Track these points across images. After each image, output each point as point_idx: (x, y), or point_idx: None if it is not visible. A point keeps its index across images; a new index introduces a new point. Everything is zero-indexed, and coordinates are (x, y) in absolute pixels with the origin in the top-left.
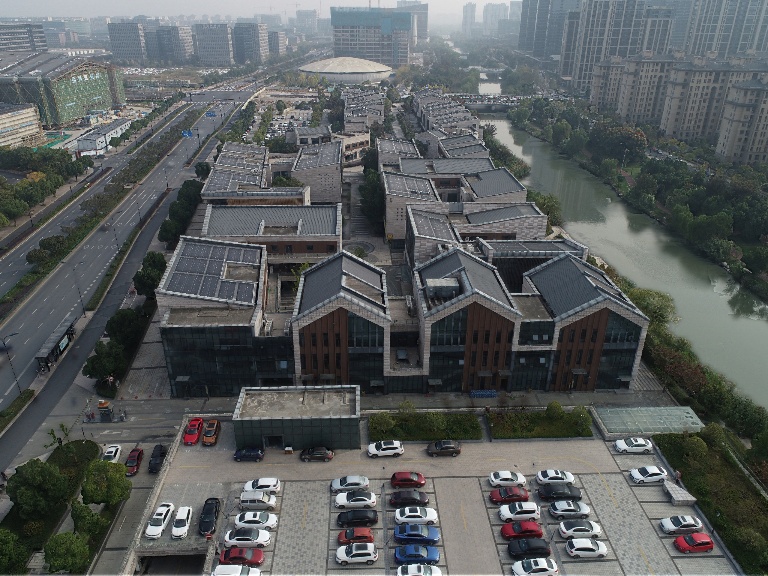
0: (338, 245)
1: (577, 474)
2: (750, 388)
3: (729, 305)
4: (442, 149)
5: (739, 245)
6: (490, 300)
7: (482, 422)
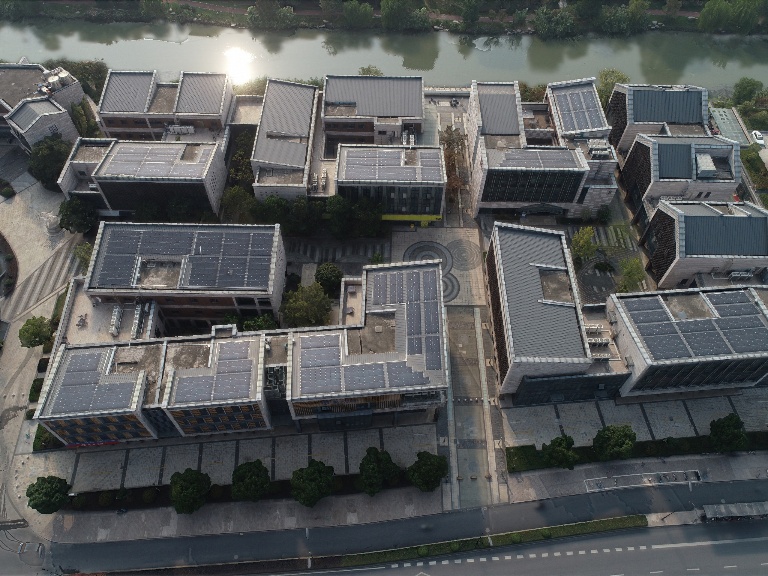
0: None
1: None
2: None
3: None
4: (151, 117)
5: None
6: None
7: (760, 193)
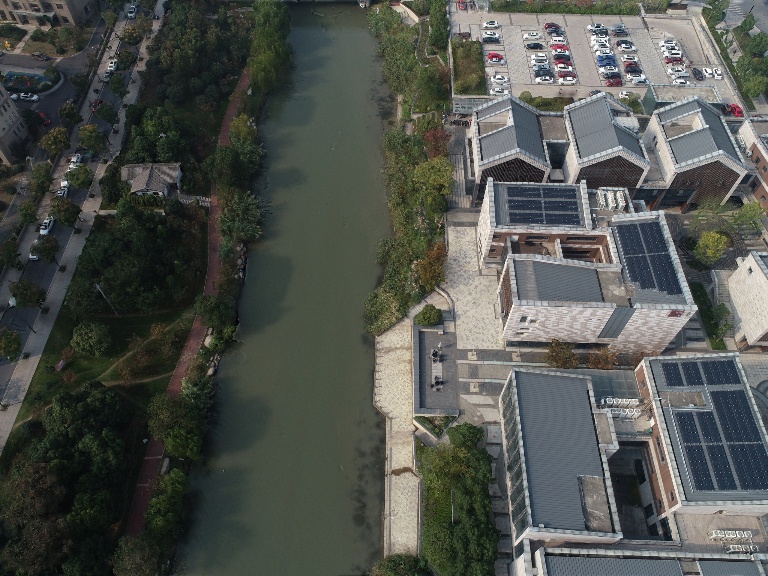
0: None
1: (532, 84)
2: (367, 177)
3: None
4: None
5: None
6: None
7: None
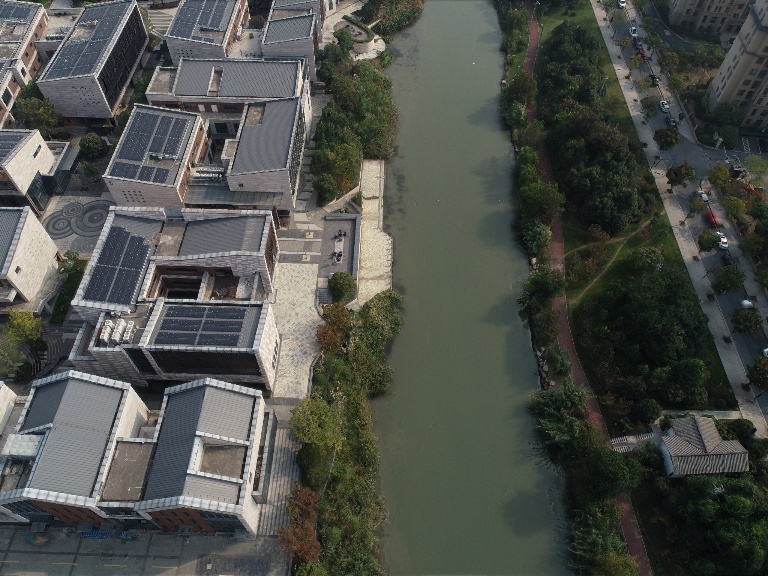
0: (10, 282)
1: None
2: (409, 514)
3: (519, 316)
4: None
5: (570, 226)
6: (45, 500)
7: None
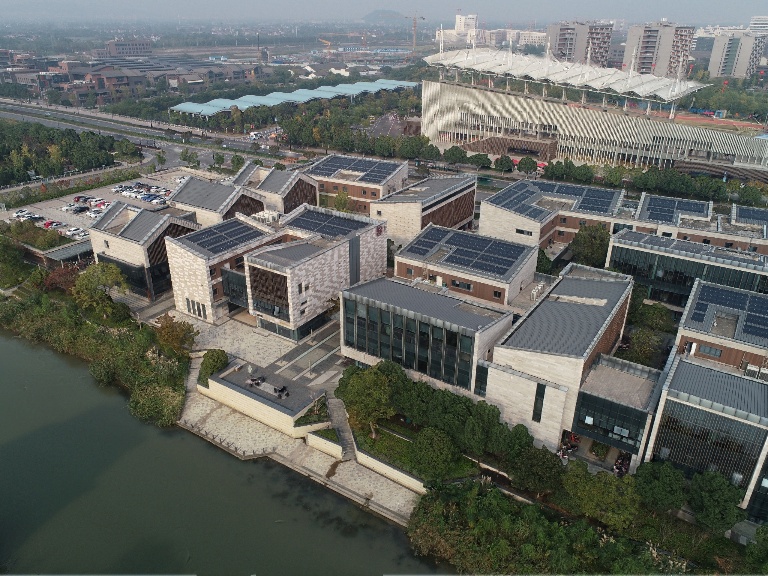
0: None
1: None
2: (4, 350)
3: None
4: None
5: None
6: None
7: None
